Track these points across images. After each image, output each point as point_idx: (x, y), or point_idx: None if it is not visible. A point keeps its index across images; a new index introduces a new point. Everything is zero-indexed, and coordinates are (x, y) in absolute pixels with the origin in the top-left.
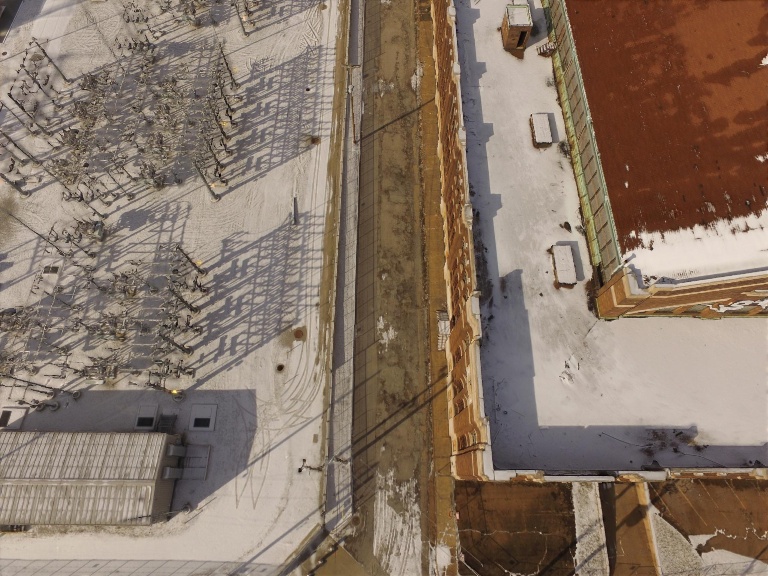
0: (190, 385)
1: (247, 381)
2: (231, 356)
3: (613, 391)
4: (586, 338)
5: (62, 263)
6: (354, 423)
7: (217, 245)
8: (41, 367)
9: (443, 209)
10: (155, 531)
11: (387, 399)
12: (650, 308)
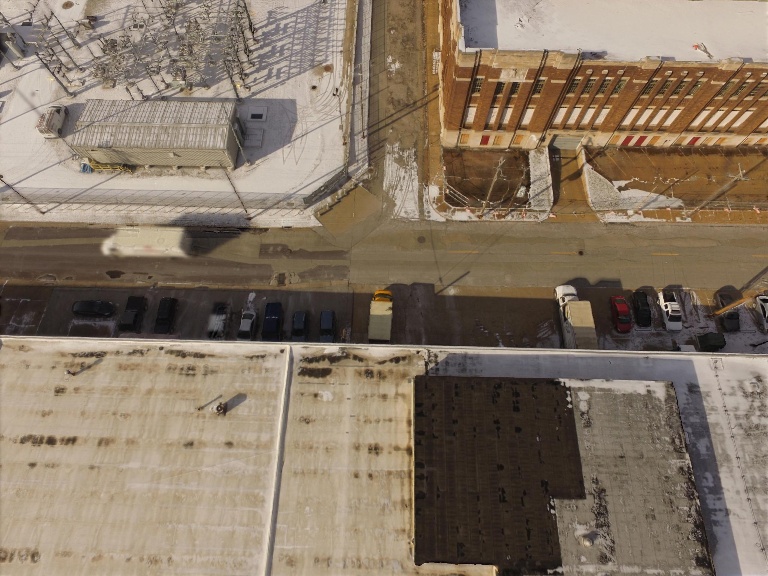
0: (247, 95)
1: (289, 94)
2: (277, 80)
3: (551, 33)
4: (535, 7)
5: (146, 22)
6: (369, 116)
7: (264, 14)
8: None
9: None
10: (225, 176)
11: (394, 102)
12: None
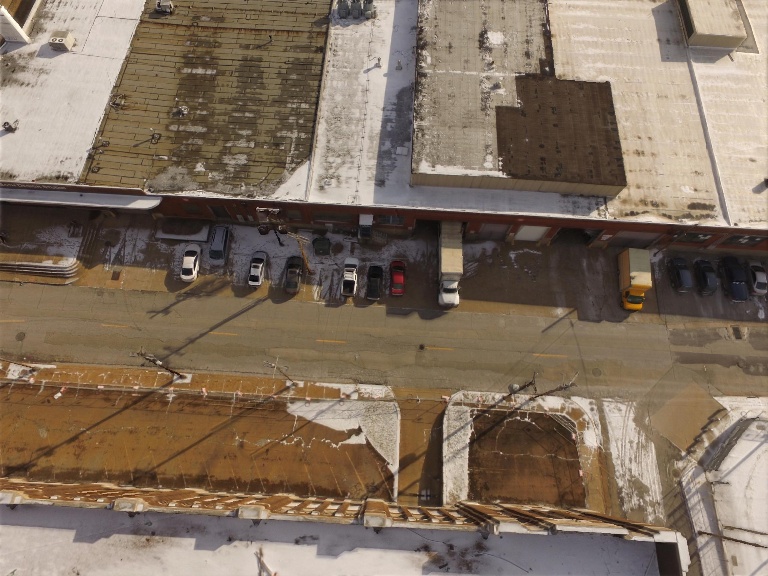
0: None
1: None
2: None
3: None
4: None
5: None
6: None
7: None
8: None
9: None
10: None
11: None
12: None
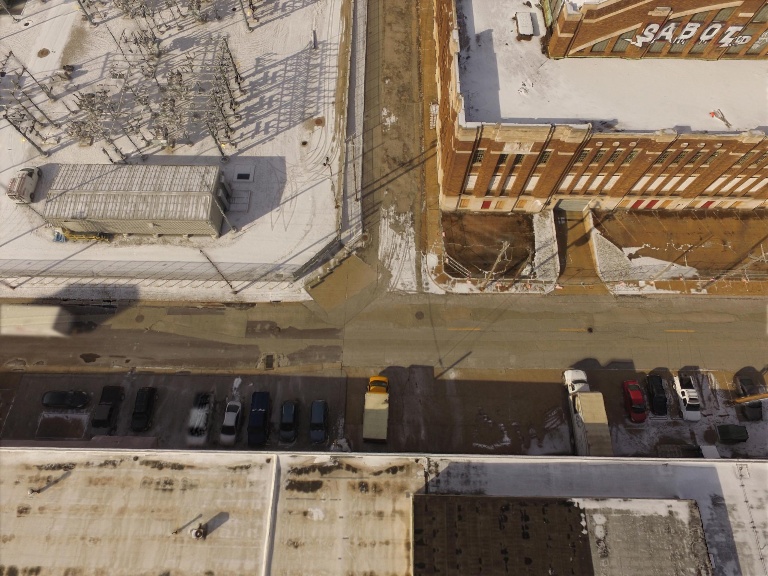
0: (233, 153)
1: (278, 151)
2: (265, 135)
3: (557, 99)
4: (539, 69)
5: (127, 72)
6: (363, 176)
7: (251, 62)
8: (115, 139)
9: (435, 31)
10: (209, 244)
11: (389, 161)
12: (586, 43)
